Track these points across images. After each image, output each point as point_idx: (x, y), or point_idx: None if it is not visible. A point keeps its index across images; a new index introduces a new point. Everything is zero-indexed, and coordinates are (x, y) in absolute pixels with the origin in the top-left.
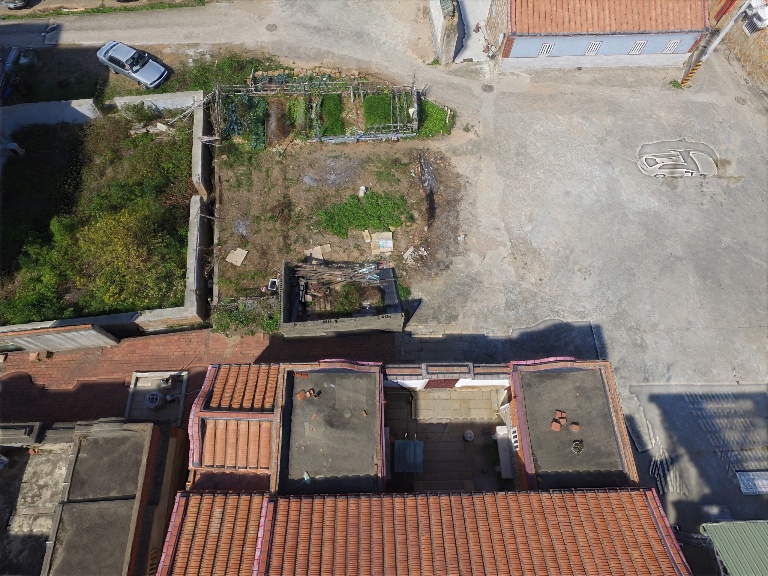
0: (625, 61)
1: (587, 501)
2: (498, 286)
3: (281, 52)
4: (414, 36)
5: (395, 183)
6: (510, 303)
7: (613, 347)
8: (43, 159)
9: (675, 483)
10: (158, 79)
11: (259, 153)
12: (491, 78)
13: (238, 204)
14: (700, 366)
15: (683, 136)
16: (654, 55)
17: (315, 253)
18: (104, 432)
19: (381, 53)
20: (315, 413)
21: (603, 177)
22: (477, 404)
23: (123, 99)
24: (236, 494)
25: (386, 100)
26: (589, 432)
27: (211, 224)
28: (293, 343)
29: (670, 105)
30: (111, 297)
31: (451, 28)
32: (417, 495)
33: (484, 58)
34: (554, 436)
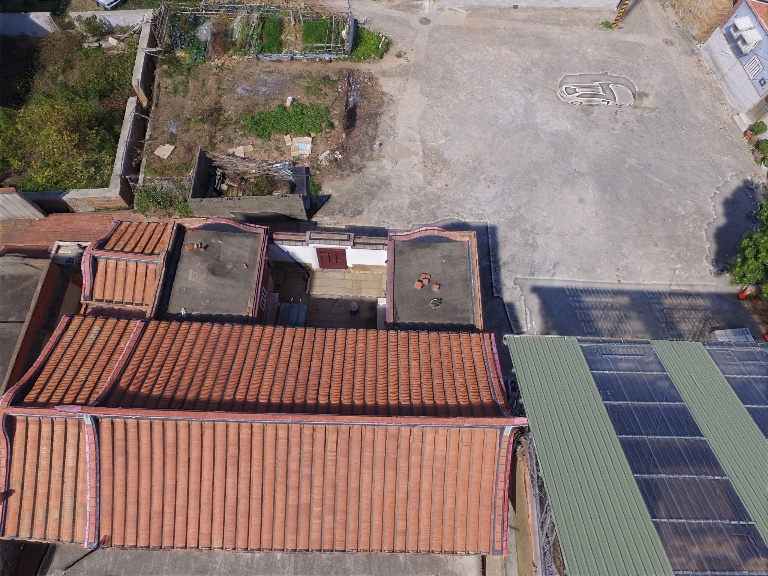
0: (559, 1)
1: (429, 339)
2: (405, 188)
3: None
4: None
5: (322, 96)
6: (414, 203)
7: (505, 245)
8: (1, 64)
9: None
10: (115, 1)
11: (198, 65)
12: (429, 12)
13: (172, 107)
14: (585, 265)
15: (606, 70)
16: None
17: (238, 152)
18: (7, 264)
19: None
20: (200, 262)
21: (522, 101)
22: (368, 285)
23: (78, 13)
24: (116, 318)
25: (324, 25)
26: (449, 292)
27: (146, 124)
28: None
29: (598, 43)
30: (44, 177)
31: None
32: (276, 326)
33: None
34: (416, 294)
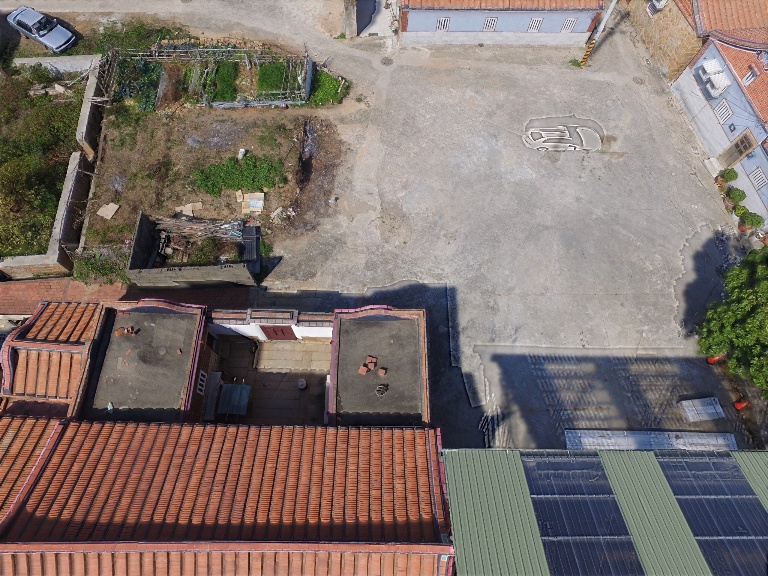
0: (525, 39)
1: (370, 437)
2: (361, 247)
3: (192, 23)
4: (325, 11)
5: (276, 147)
6: (370, 263)
7: (465, 308)
8: None
9: (502, 438)
10: (64, 44)
11: (148, 115)
12: (392, 52)
13: (118, 162)
14: (548, 329)
15: (573, 112)
16: (553, 33)
17: (186, 210)
18: None
19: (290, 26)
20: (130, 349)
21: (485, 148)
22: (319, 356)
23: (23, 60)
24: (34, 418)
25: (281, 69)
26: (396, 377)
27: (90, 180)
28: (149, 293)
29: (566, 83)
30: None
31: (349, 1)
32: (207, 425)
33: (389, 33)
34: (361, 380)
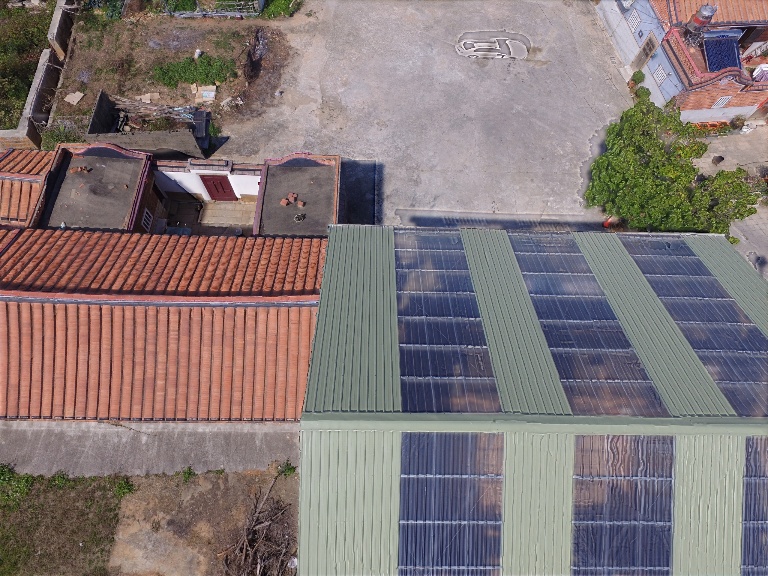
0: None
1: (283, 244)
2: (301, 131)
3: None
4: None
5: (230, 50)
6: (308, 144)
7: (390, 180)
8: None
9: None
10: None
11: (114, 22)
12: None
13: (86, 59)
14: (464, 198)
15: (504, 28)
16: None
17: (144, 99)
18: None
19: None
20: (83, 183)
21: (421, 55)
22: None
23: None
24: None
25: None
26: (313, 209)
27: (59, 74)
28: None
29: (500, 3)
30: None
31: None
32: (144, 234)
33: None
34: (283, 211)
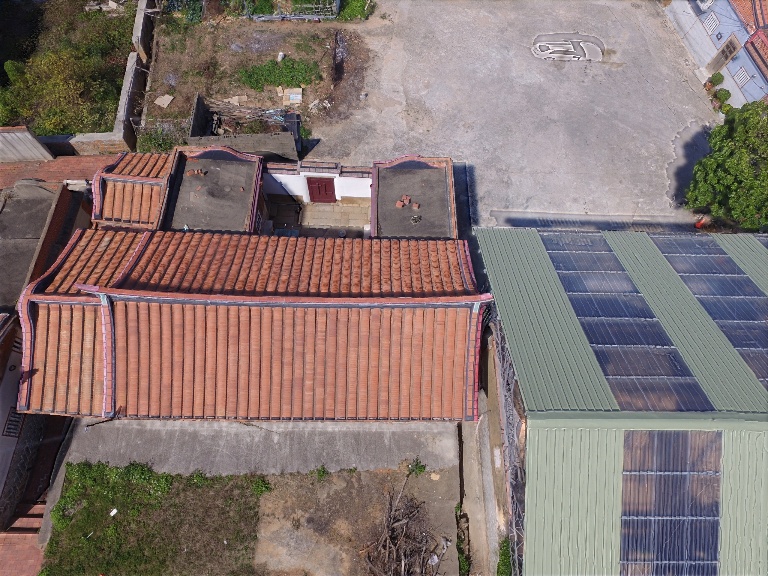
0: None
1: (409, 245)
2: (389, 133)
3: None
4: None
5: (311, 53)
6: (398, 146)
7: (482, 182)
8: (6, 26)
9: None
10: None
11: (195, 25)
12: None
13: (171, 62)
14: (556, 199)
15: (577, 30)
16: None
17: (233, 101)
18: (23, 187)
19: None
20: (200, 186)
21: (498, 57)
22: (355, 216)
23: None
24: (124, 231)
25: None
26: (428, 211)
27: (146, 77)
28: None
29: (570, 6)
30: (51, 124)
31: None
32: (271, 236)
33: None
34: (398, 213)
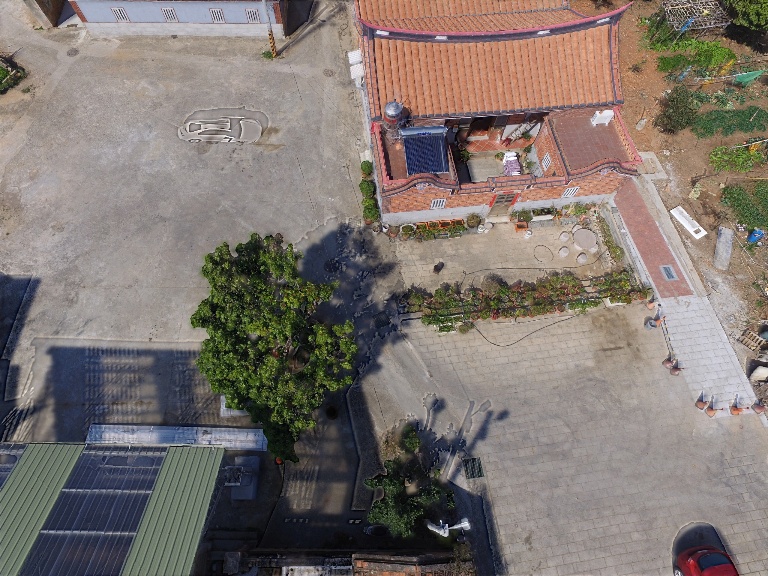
0: (217, 30)
1: None
2: None
3: None
4: None
5: None
6: None
7: (40, 300)
8: None
9: (23, 432)
10: None
11: None
12: (82, 43)
13: None
14: (120, 322)
15: (244, 104)
16: (243, 25)
17: None
18: None
19: None
20: None
21: (135, 140)
22: None
23: None
24: None
25: None
26: None
27: None
28: None
29: (249, 74)
30: None
31: None
32: None
33: None
34: None
